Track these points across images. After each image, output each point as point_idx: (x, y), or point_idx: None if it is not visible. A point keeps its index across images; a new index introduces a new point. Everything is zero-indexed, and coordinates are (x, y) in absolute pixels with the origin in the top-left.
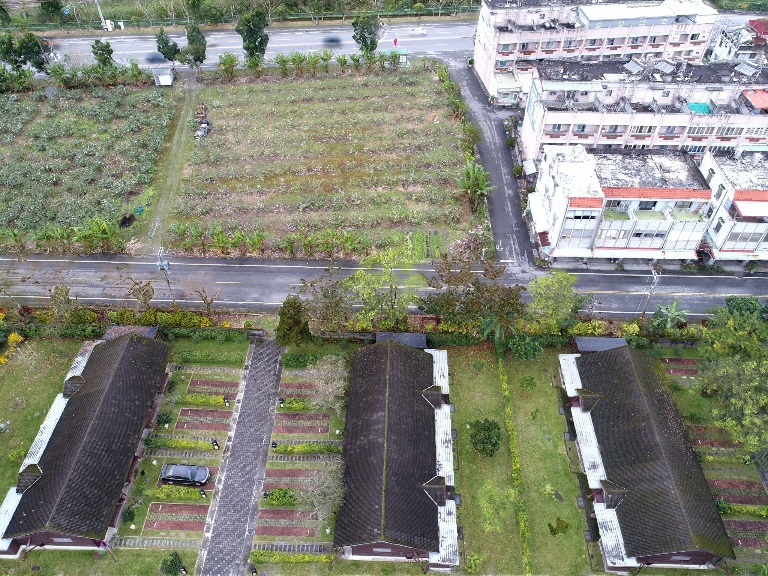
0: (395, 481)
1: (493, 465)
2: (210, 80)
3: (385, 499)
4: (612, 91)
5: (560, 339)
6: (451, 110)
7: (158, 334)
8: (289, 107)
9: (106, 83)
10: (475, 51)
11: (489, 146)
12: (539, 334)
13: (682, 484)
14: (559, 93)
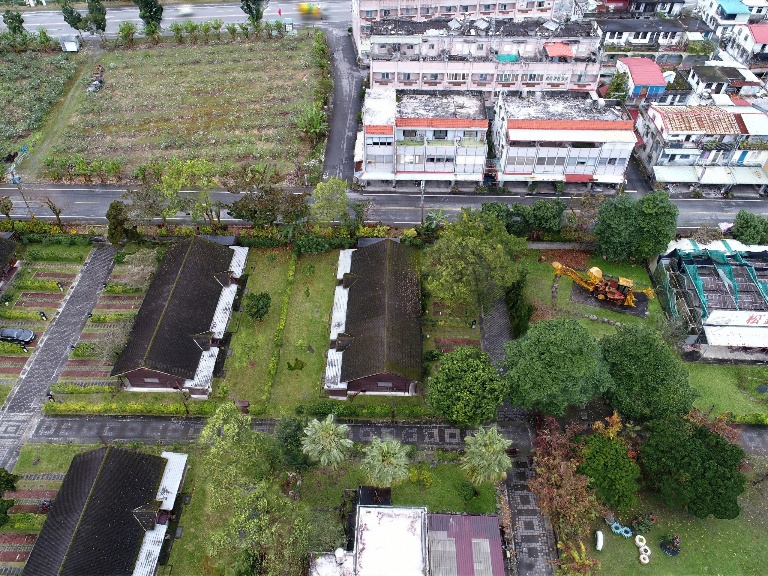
0: (167, 330)
1: (266, 329)
2: (113, 47)
3: (154, 340)
4: (434, 44)
5: (348, 240)
6: (320, 70)
7: (14, 239)
8: (177, 68)
9: (18, 49)
10: (352, 20)
11: (344, 98)
12: (332, 237)
13: (394, 331)
14: (388, 47)
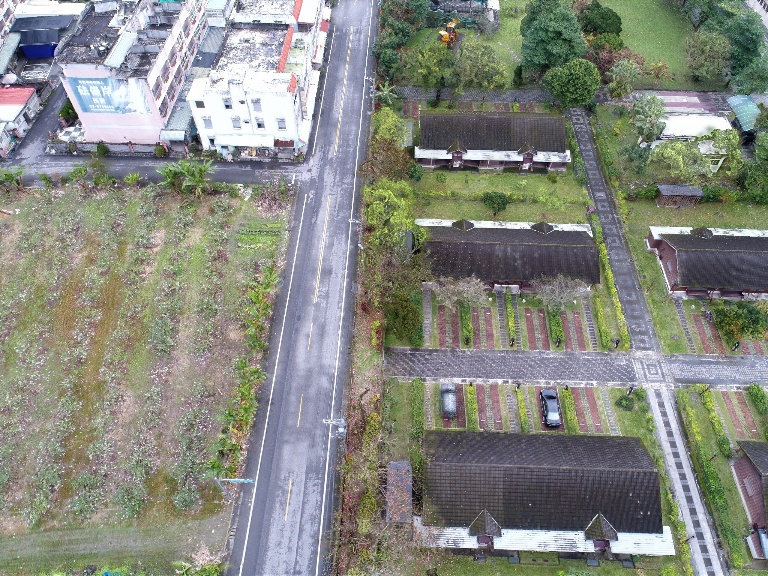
0: None
1: (504, 211)
2: None
3: None
4: None
5: None
6: None
7: None
8: None
9: None
10: None
11: None
12: None
13: None
14: None
